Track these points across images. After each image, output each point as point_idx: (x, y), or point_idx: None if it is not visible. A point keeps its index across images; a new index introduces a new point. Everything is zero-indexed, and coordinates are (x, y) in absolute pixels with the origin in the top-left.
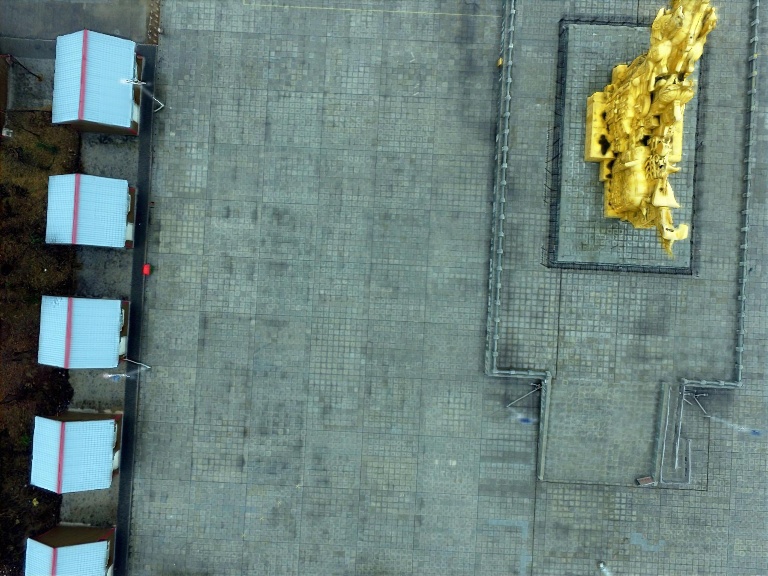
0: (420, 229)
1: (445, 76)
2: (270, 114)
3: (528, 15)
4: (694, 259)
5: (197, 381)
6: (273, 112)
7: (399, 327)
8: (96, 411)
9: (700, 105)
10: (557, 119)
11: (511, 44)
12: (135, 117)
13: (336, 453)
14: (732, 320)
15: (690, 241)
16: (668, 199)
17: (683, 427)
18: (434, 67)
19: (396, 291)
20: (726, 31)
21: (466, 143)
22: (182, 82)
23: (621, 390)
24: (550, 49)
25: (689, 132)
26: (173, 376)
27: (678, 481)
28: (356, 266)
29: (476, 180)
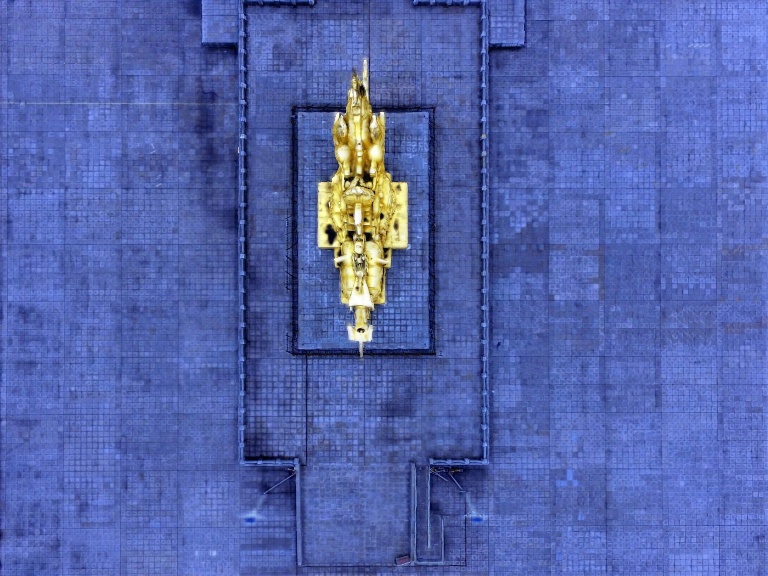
0: (169, 320)
1: (187, 166)
2: (11, 212)
3: (261, 104)
4: (437, 339)
5: None
6: (14, 210)
7: (152, 420)
8: None
9: (435, 186)
10: (295, 206)
11: (242, 135)
12: None
13: (94, 550)
14: (477, 397)
15: (431, 321)
16: (364, 298)
17: (440, 504)
18: (175, 157)
19: (148, 384)
20: (457, 112)
21: (211, 232)
22: None
23: (372, 472)
24: (284, 137)
25: (422, 215)
26: None
27: (434, 559)
28: (106, 361)
29: (223, 268)
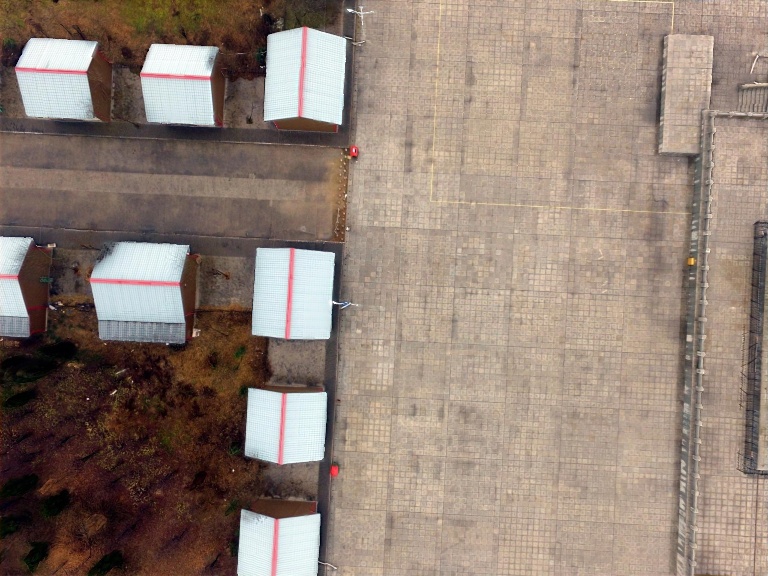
0: (609, 428)
1: (634, 273)
2: (457, 311)
3: (723, 217)
4: None
5: None
6: (460, 309)
7: (588, 528)
8: None
9: None
10: (753, 322)
11: (708, 249)
12: None
13: None
14: None
15: None
16: None
17: None
18: (623, 264)
19: (585, 491)
20: None
21: (655, 341)
22: (368, 279)
23: None
24: (745, 252)
25: None
26: None
27: None
28: (544, 465)
29: (666, 379)
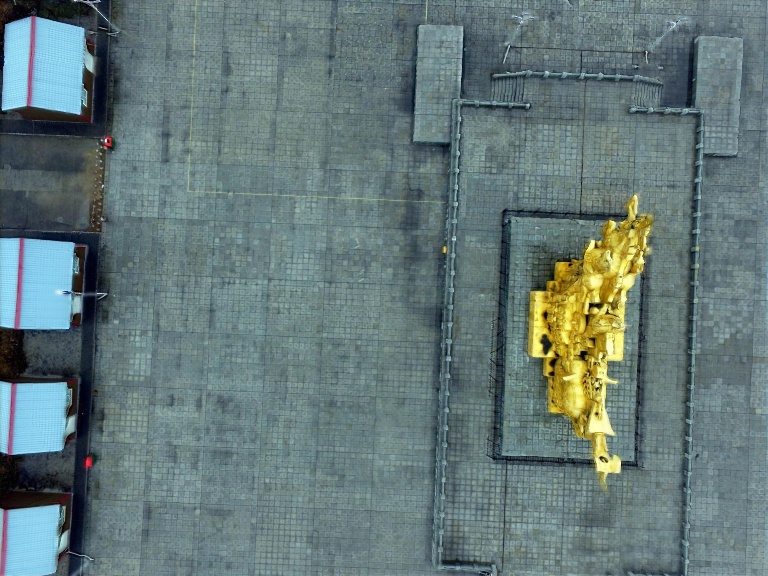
0: (366, 416)
1: (390, 262)
2: (214, 301)
3: (471, 205)
4: (639, 450)
5: (141, 572)
6: (217, 299)
7: (345, 516)
8: None
9: (644, 295)
10: (501, 309)
11: (454, 237)
12: (77, 308)
13: None
14: (678, 511)
15: (635, 432)
16: (603, 424)
17: None
18: (379, 253)
19: (342, 479)
20: (669, 221)
21: (412, 329)
22: (126, 269)
23: None
24: (494, 239)
25: (632, 325)
26: (117, 568)
27: None
28: (302, 454)
29: (422, 366)
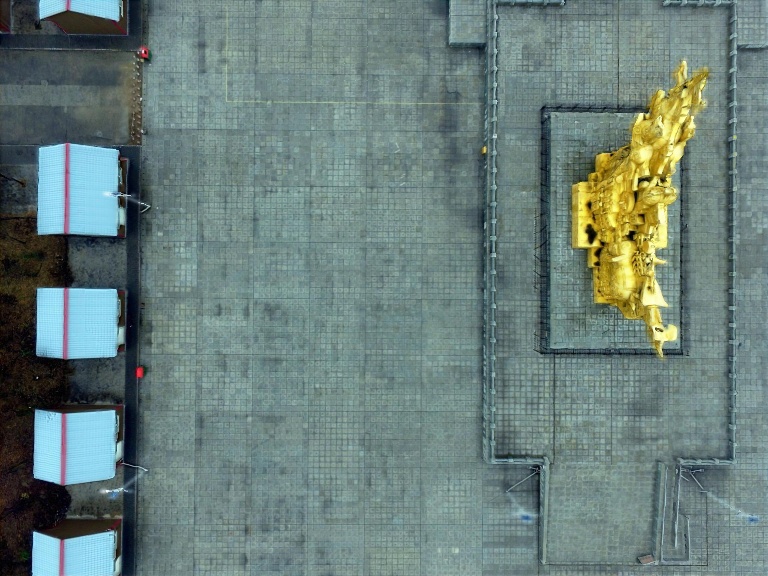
0: (412, 318)
1: (431, 165)
2: (258, 210)
3: (510, 104)
4: (684, 339)
5: (196, 481)
6: (260, 208)
7: (396, 417)
8: (95, 517)
9: (683, 186)
10: (543, 206)
11: (495, 134)
12: (122, 220)
13: (338, 546)
14: (724, 397)
15: (679, 321)
16: (656, 297)
17: (681, 503)
18: (419, 157)
19: (391, 381)
20: (705, 112)
21: (454, 231)
22: (168, 182)
23: (618, 472)
24: (533, 137)
25: (674, 215)
26: (171, 477)
27: (678, 558)
28: (350, 358)
29: (466, 267)
